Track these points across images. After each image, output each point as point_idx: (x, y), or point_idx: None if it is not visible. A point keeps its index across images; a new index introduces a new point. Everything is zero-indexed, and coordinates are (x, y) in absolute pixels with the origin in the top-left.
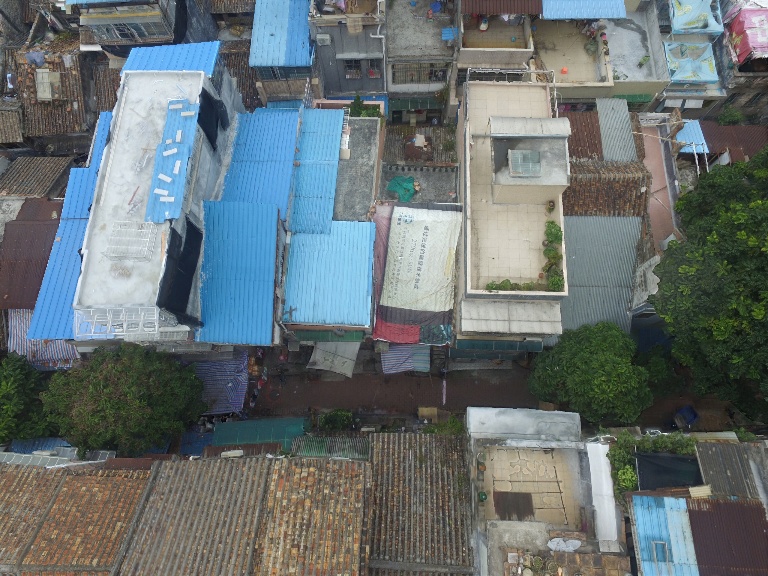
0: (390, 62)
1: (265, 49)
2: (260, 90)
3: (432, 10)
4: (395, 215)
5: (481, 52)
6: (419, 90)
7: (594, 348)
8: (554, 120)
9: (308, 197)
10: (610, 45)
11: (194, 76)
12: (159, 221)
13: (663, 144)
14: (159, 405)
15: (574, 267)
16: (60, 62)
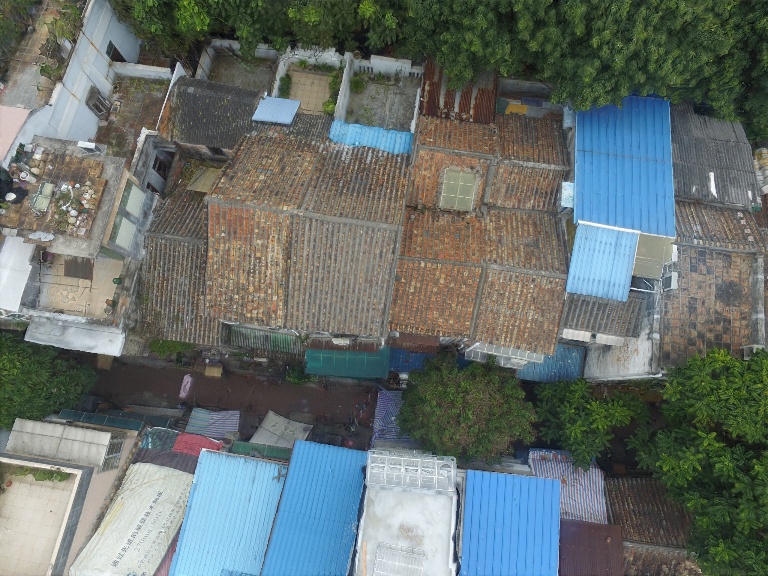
0: None
1: None
2: None
3: None
4: None
5: None
6: None
7: (5, 404)
8: None
9: None
10: None
11: None
12: None
13: None
14: None
15: None
16: None
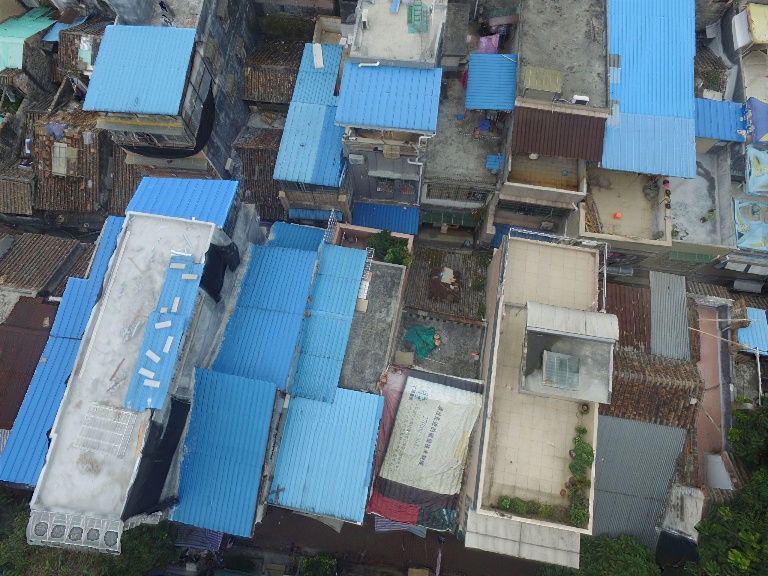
0: (426, 183)
1: (292, 161)
2: (282, 199)
3: (479, 128)
4: (407, 389)
5: (527, 189)
6: (455, 205)
7: (613, 574)
8: (601, 318)
9: (314, 355)
10: (672, 190)
11: (204, 227)
12: (139, 409)
13: (721, 332)
14: (123, 571)
15: (601, 470)
16: (79, 138)
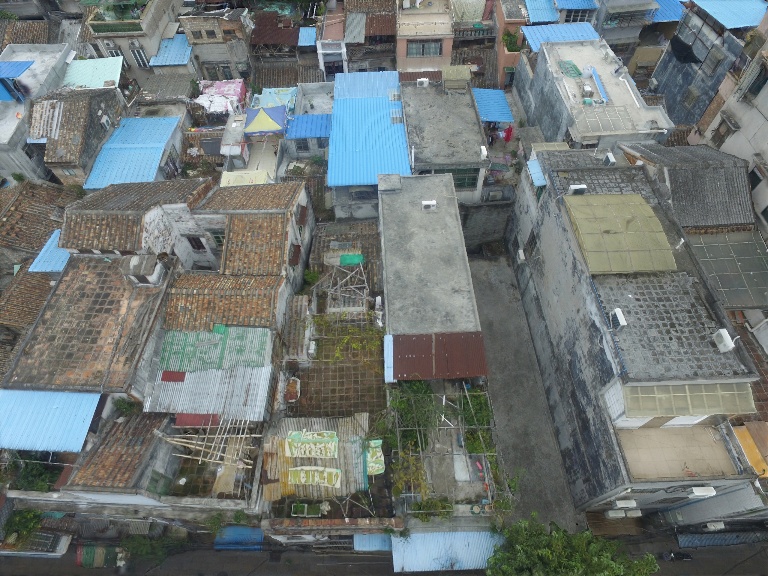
0: None
1: None
2: None
3: None
4: None
5: None
6: None
7: None
8: None
9: None
10: None
11: None
12: None
13: None
14: None
15: None
16: None
